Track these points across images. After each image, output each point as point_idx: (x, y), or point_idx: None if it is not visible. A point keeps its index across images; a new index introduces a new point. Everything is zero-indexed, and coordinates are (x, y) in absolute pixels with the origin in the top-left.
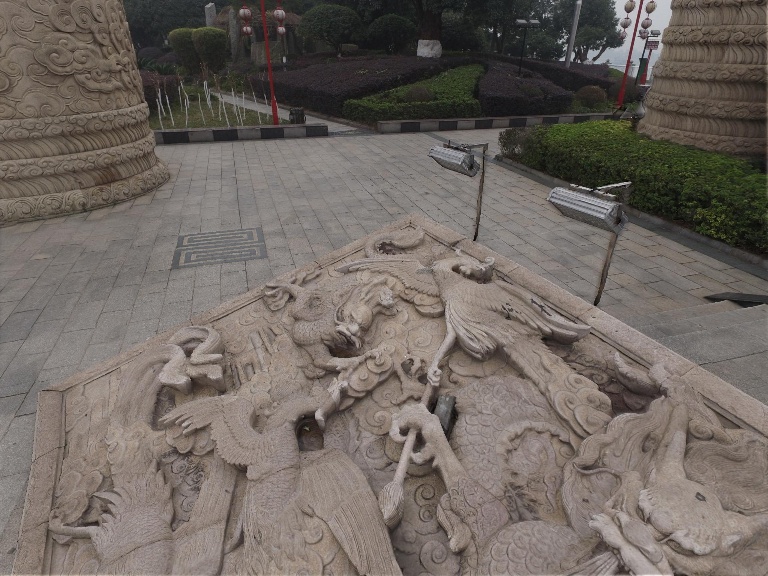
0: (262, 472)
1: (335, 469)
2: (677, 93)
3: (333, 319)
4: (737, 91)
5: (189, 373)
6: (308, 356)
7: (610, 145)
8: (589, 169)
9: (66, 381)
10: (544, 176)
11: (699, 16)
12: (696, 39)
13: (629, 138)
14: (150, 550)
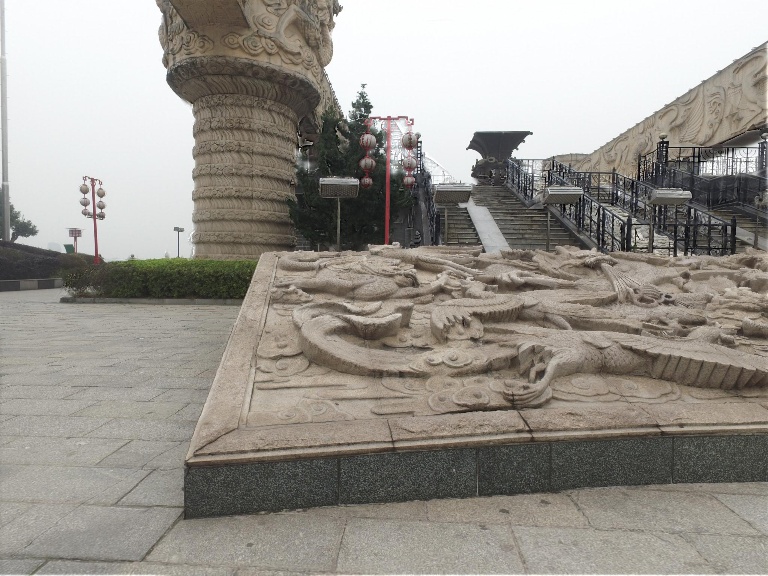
0: (534, 299)
1: (534, 294)
2: (229, 230)
3: (384, 277)
4: (266, 227)
5: (386, 314)
6: (402, 299)
7: (209, 263)
8: (208, 280)
9: (220, 419)
10: (150, 301)
11: (227, 180)
12: (231, 194)
13: (212, 261)
14: (585, 331)
